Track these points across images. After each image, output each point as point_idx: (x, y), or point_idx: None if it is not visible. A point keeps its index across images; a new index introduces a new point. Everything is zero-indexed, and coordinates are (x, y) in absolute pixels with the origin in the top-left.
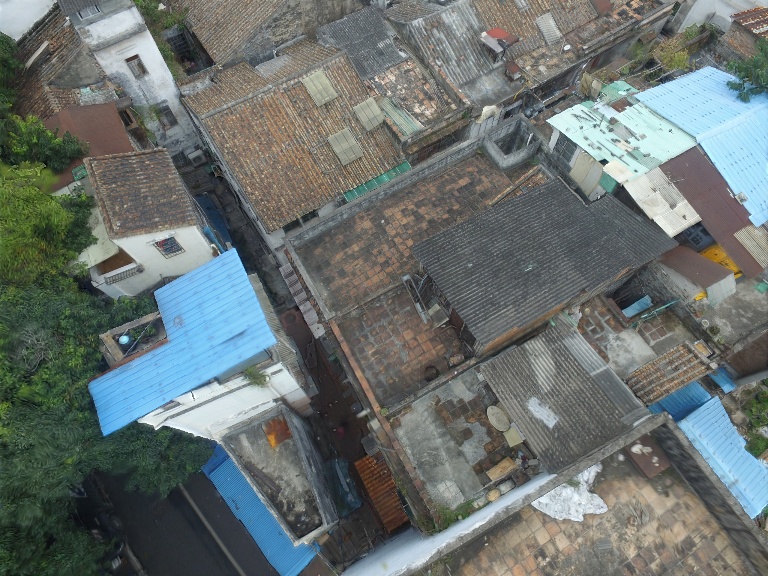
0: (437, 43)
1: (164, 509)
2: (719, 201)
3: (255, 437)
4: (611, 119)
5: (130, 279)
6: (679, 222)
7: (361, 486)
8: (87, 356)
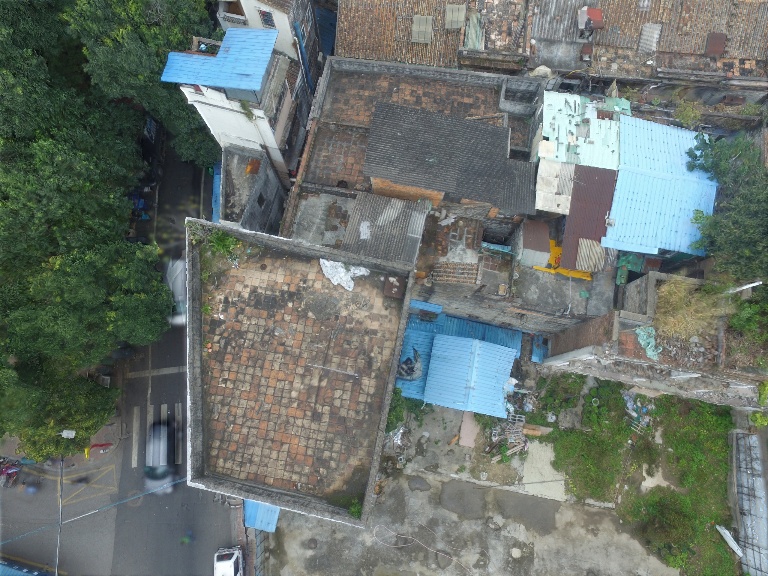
0: None
1: (187, 184)
2: (593, 213)
3: (242, 161)
4: (586, 118)
5: (238, 26)
6: (551, 205)
7: None
8: (181, 42)
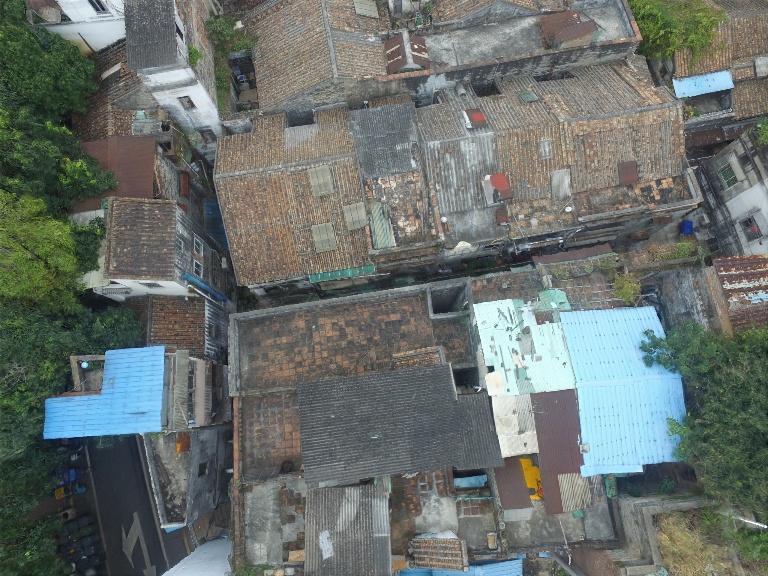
0: (444, 168)
1: None
2: (564, 443)
3: (169, 439)
4: (526, 328)
5: None
6: (518, 447)
7: None
8: (57, 369)
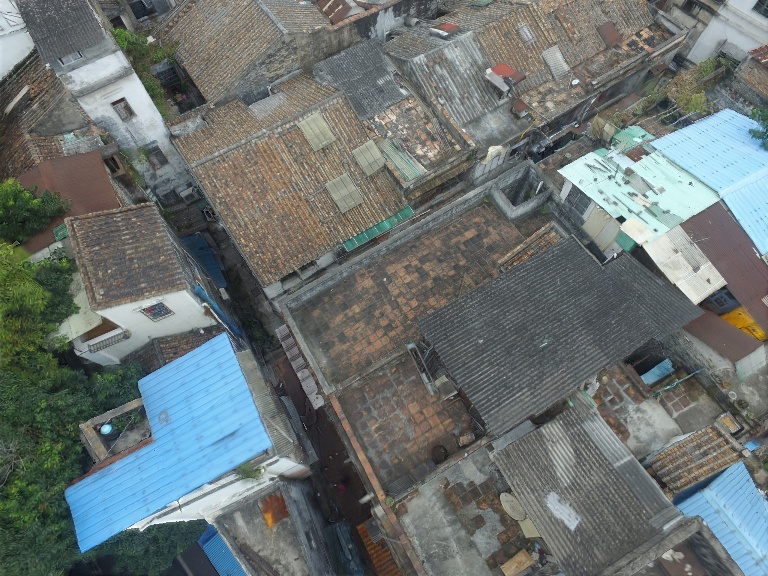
0: (439, 80)
1: None
2: (745, 262)
3: (251, 515)
4: (627, 170)
5: (116, 344)
6: (703, 287)
7: (364, 552)
8: (65, 450)
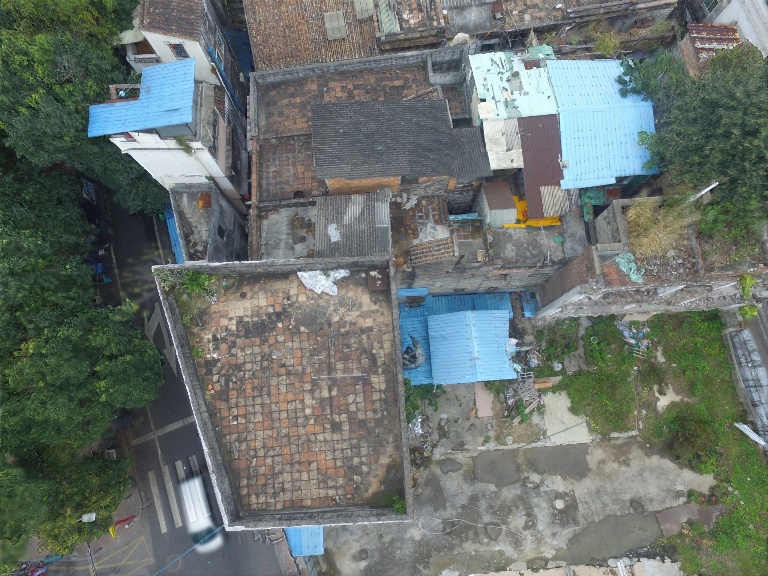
0: None
1: (141, 237)
2: (546, 160)
3: (192, 199)
4: (515, 72)
5: (152, 65)
6: (505, 162)
7: None
8: (98, 94)
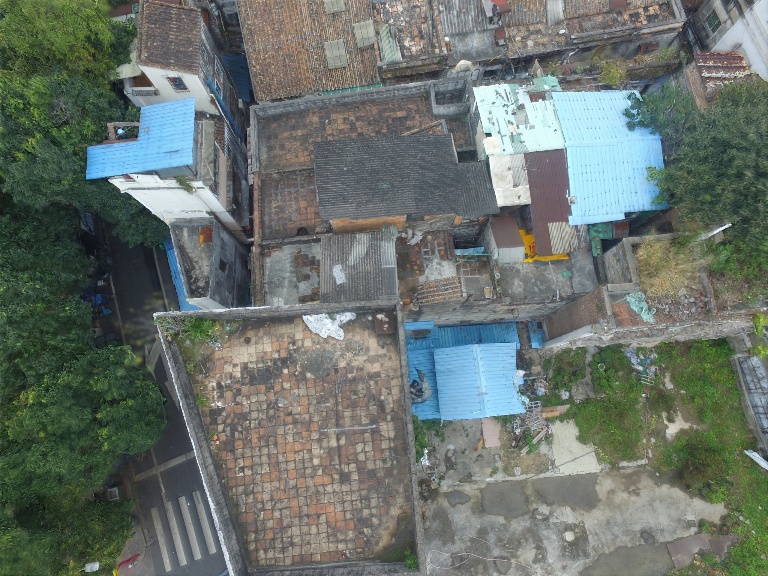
0: None
1: (140, 266)
2: (554, 196)
3: (192, 233)
4: (521, 105)
5: (150, 97)
6: (512, 198)
7: None
8: (96, 133)
